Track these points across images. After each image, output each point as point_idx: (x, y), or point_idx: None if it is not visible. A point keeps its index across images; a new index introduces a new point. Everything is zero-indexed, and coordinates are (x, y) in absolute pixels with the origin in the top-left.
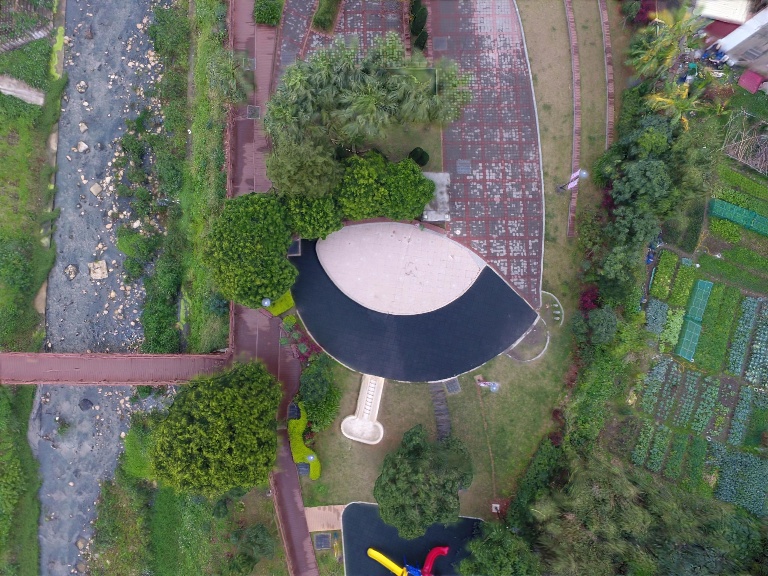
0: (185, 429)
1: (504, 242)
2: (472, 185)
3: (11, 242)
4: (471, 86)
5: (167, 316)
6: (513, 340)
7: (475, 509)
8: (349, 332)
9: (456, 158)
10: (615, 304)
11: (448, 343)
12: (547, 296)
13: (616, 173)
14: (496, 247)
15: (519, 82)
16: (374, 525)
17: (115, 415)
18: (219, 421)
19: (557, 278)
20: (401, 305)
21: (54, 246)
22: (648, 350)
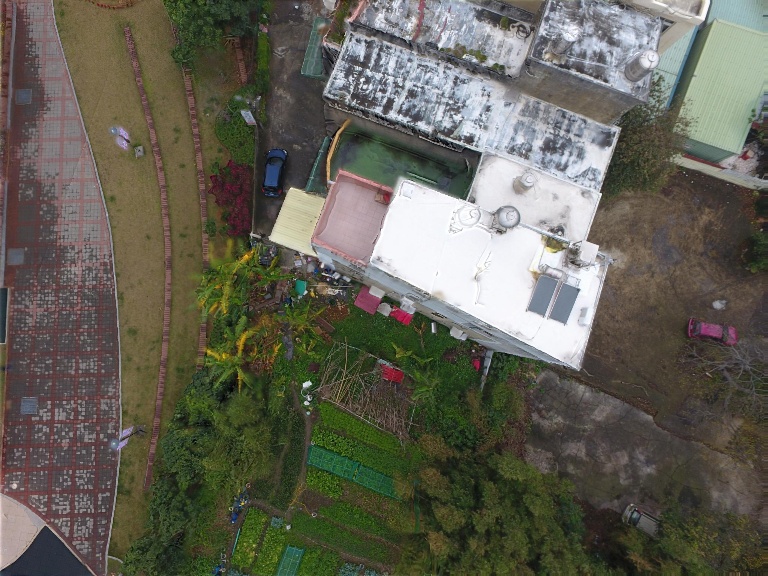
0: None
1: (69, 497)
2: (37, 428)
3: None
4: (47, 307)
5: None
6: None
7: None
8: None
9: (20, 395)
10: None
11: None
12: (113, 562)
13: None
14: (59, 503)
15: (103, 302)
16: None
17: None
18: None
19: (128, 540)
20: None
21: None
22: None
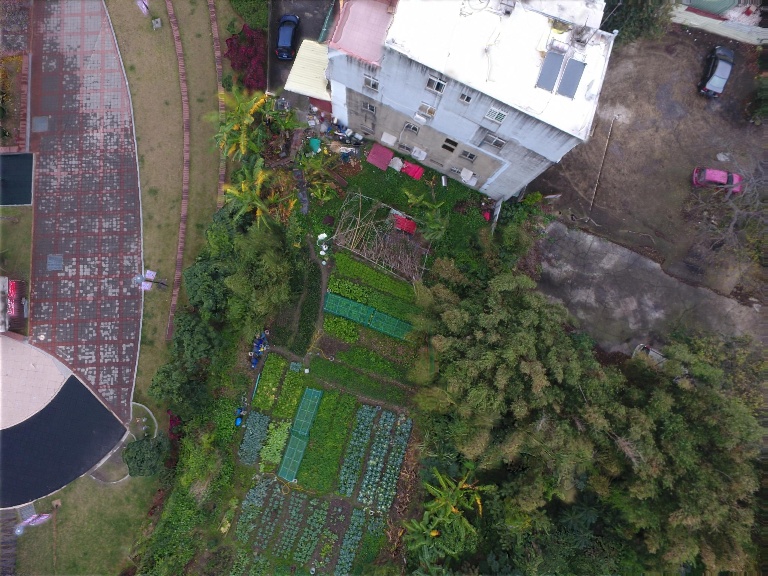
0: None
1: (94, 347)
2: (63, 283)
3: None
4: (71, 171)
5: None
6: (97, 459)
7: None
8: None
9: (47, 253)
10: (203, 419)
11: (24, 464)
12: (138, 408)
13: None
14: (85, 353)
15: (125, 164)
16: None
17: None
18: None
19: None
20: None
21: None
22: None
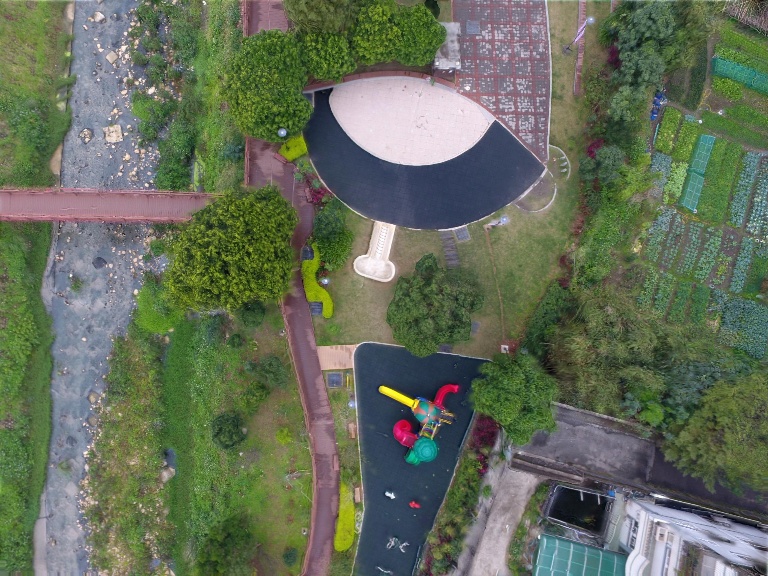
0: (204, 235)
1: (512, 98)
2: (481, 45)
3: (28, 100)
4: None
5: (181, 177)
6: (521, 191)
7: (484, 350)
8: (361, 181)
9: (466, 19)
10: None
11: (458, 193)
12: (554, 150)
13: (621, 26)
14: (505, 103)
15: None
16: (385, 364)
17: (128, 273)
18: (238, 222)
19: (564, 133)
20: (412, 156)
21: (70, 110)
22: (653, 187)
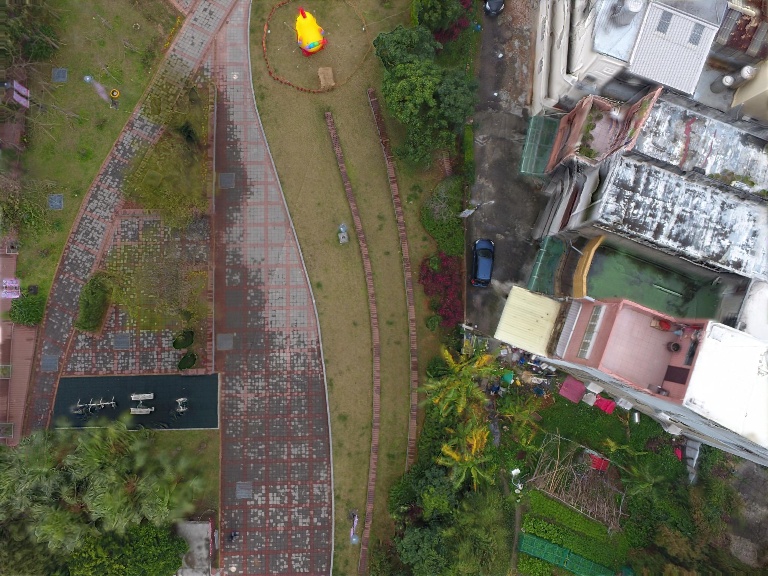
0: None
1: None
2: (253, 512)
3: None
4: (257, 393)
5: None
6: None
7: None
8: None
9: (236, 480)
10: None
11: None
12: None
13: (401, 523)
14: None
15: (312, 387)
16: None
17: None
18: None
19: None
20: None
21: None
22: None
